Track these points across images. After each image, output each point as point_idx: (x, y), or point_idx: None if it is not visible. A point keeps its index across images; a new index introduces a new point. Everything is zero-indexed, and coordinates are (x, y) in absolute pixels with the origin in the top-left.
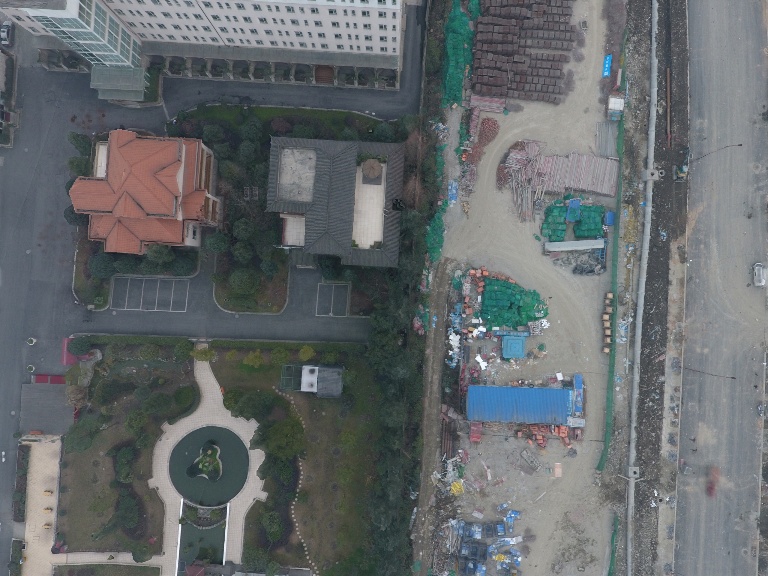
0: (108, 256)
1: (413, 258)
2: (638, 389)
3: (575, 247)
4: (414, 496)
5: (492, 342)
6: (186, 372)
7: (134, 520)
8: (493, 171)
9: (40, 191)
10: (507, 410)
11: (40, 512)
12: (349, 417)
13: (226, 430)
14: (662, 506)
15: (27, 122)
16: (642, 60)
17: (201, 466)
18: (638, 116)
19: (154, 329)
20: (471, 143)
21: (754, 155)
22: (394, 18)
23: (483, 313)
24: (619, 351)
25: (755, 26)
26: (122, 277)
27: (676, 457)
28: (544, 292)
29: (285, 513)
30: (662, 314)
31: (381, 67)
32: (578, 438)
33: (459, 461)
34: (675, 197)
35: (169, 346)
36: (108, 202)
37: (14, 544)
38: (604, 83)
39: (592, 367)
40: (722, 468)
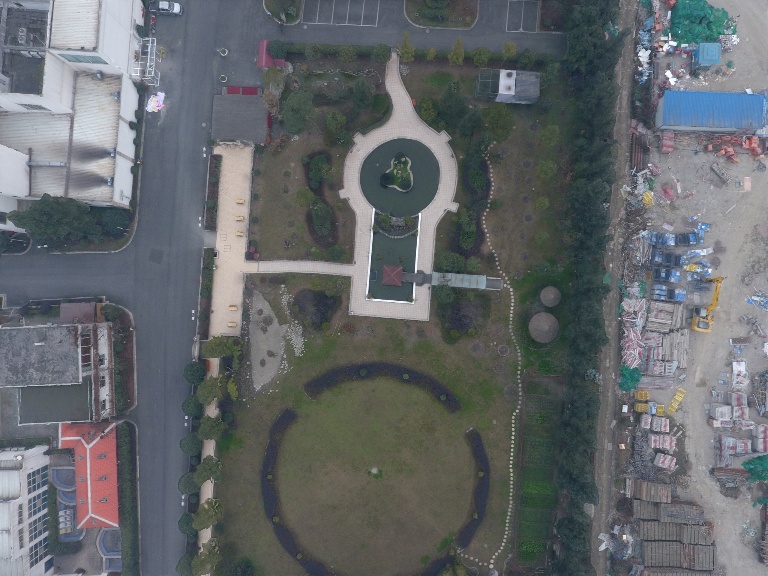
0: None
1: None
2: None
3: None
4: (605, 208)
5: (681, 59)
6: (378, 84)
7: (327, 227)
8: None
9: None
10: (703, 115)
11: (231, 222)
12: (539, 130)
13: (417, 142)
14: None
15: None
16: None
17: (395, 172)
18: None
19: (345, 43)
20: None
21: None
22: None
23: (674, 27)
24: None
25: None
26: None
27: None
28: (732, 11)
29: (478, 220)
30: None
31: None
32: None
33: (649, 174)
34: None
35: (361, 58)
36: None
37: (207, 251)
38: None
39: None
40: None
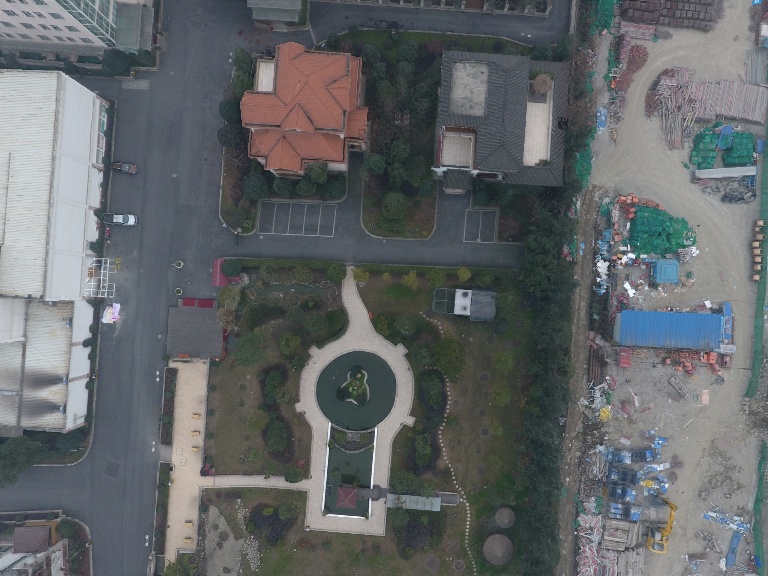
0: (262, 177)
1: None
2: None
3: (726, 174)
4: (562, 422)
5: (640, 269)
6: (334, 296)
7: (283, 443)
8: (642, 98)
9: (186, 115)
10: (660, 335)
11: (187, 435)
12: (497, 343)
13: (373, 355)
14: None
15: (173, 45)
16: None
17: (351, 389)
18: None
19: (301, 254)
20: (620, 70)
21: None
22: None
23: (633, 240)
24: (767, 279)
25: None
26: (269, 201)
27: None
28: (692, 220)
29: (434, 437)
30: None
31: None
32: (727, 365)
33: (607, 388)
34: None
35: (317, 270)
36: (278, 115)
37: (162, 466)
38: (755, 10)
39: (740, 295)
40: None
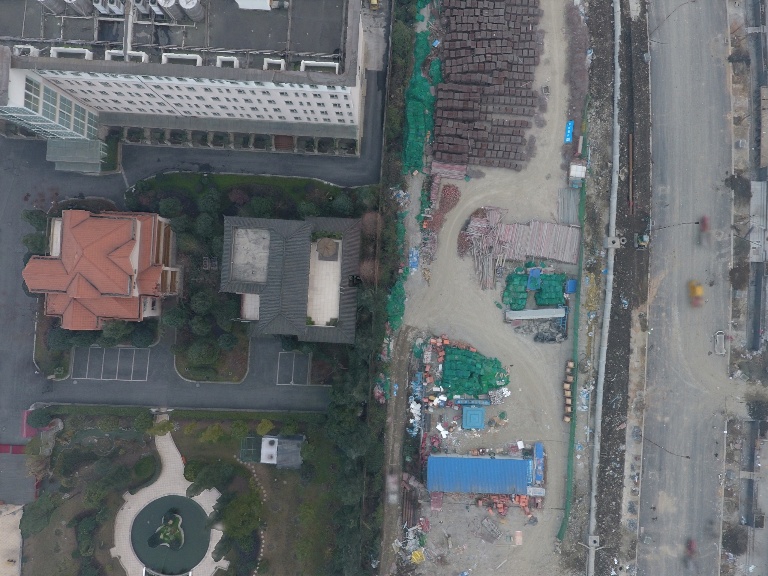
0: (66, 329)
1: (373, 329)
2: (598, 458)
3: (536, 316)
4: (375, 564)
5: (453, 410)
6: (147, 442)
7: None
8: (454, 238)
9: None
10: (467, 481)
11: None
12: (310, 486)
13: (188, 499)
14: (622, 574)
15: None
16: (604, 126)
17: (162, 536)
18: (600, 182)
19: (115, 398)
20: (432, 210)
21: (716, 222)
22: (346, 99)
23: (444, 382)
24: (580, 419)
25: (718, 91)
26: None
27: (636, 526)
28: (505, 360)
29: None
30: (623, 382)
31: (339, 137)
32: (538, 507)
33: (420, 529)
34: (637, 265)
35: (130, 416)
36: (62, 282)
37: None
38: (566, 149)
39: (553, 435)
40: (682, 536)
